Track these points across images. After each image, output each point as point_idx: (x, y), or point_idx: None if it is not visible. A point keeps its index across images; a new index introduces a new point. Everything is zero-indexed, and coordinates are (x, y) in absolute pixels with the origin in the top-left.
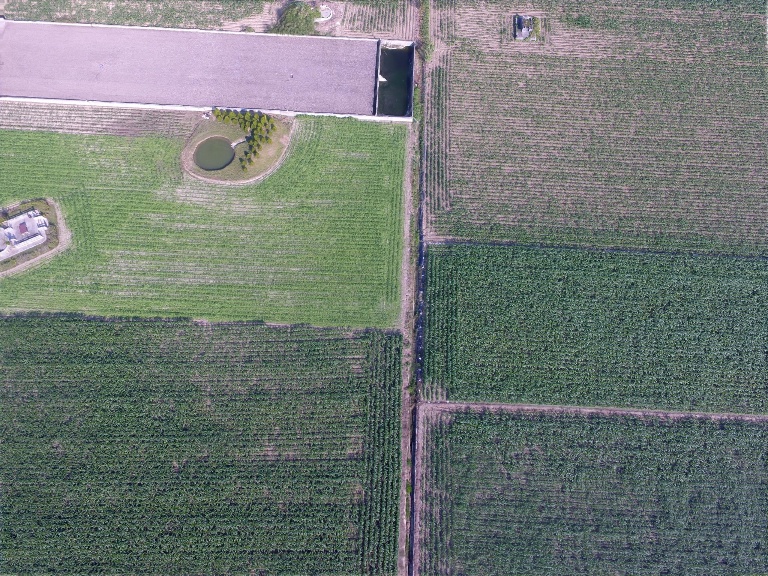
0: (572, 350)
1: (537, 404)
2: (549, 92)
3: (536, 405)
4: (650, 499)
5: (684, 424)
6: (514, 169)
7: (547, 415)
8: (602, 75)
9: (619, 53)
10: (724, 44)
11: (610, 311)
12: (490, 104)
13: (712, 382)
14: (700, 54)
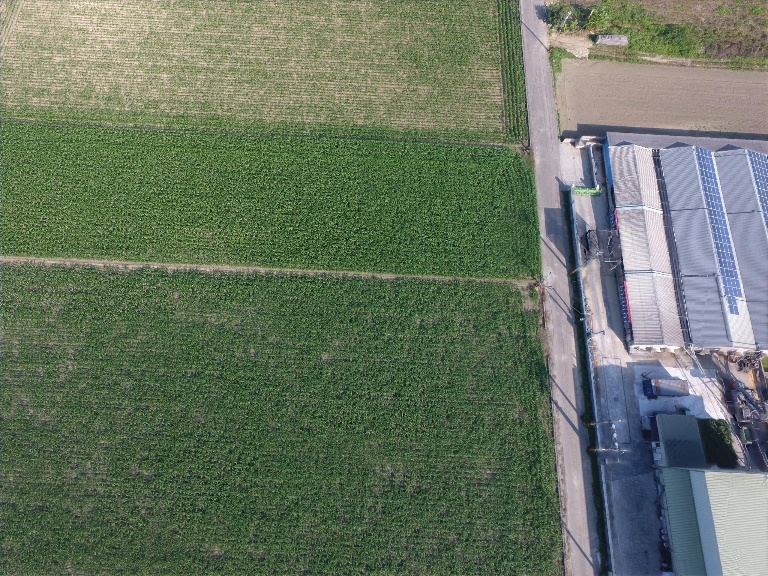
0: (52, 210)
1: (4, 256)
2: None
3: (4, 257)
4: (77, 335)
5: (135, 272)
6: (65, 59)
7: (8, 265)
8: None
9: None
10: None
11: (101, 177)
12: (62, 4)
13: (176, 237)
14: None
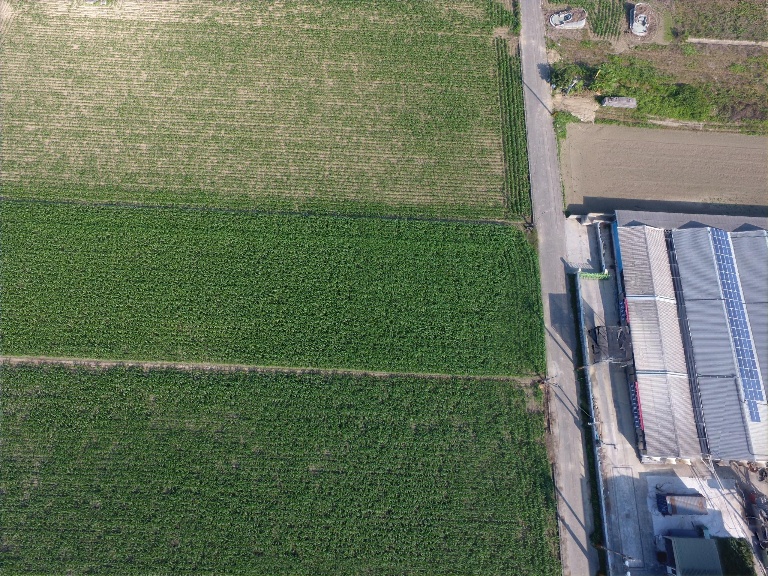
0: (20, 301)
1: None
2: (100, 54)
3: None
4: (44, 445)
5: (108, 372)
6: (37, 127)
7: None
8: (161, 38)
9: (188, 17)
10: (298, 8)
11: (73, 263)
12: (35, 65)
13: (153, 331)
14: (270, 18)
